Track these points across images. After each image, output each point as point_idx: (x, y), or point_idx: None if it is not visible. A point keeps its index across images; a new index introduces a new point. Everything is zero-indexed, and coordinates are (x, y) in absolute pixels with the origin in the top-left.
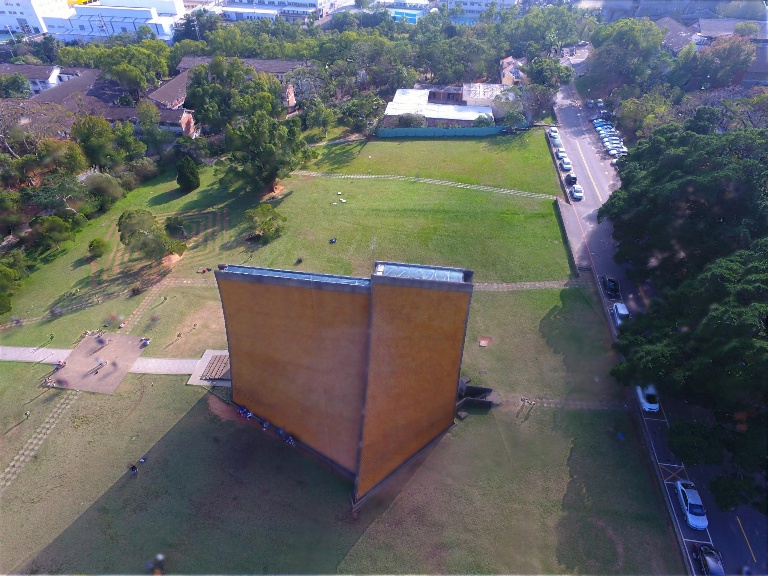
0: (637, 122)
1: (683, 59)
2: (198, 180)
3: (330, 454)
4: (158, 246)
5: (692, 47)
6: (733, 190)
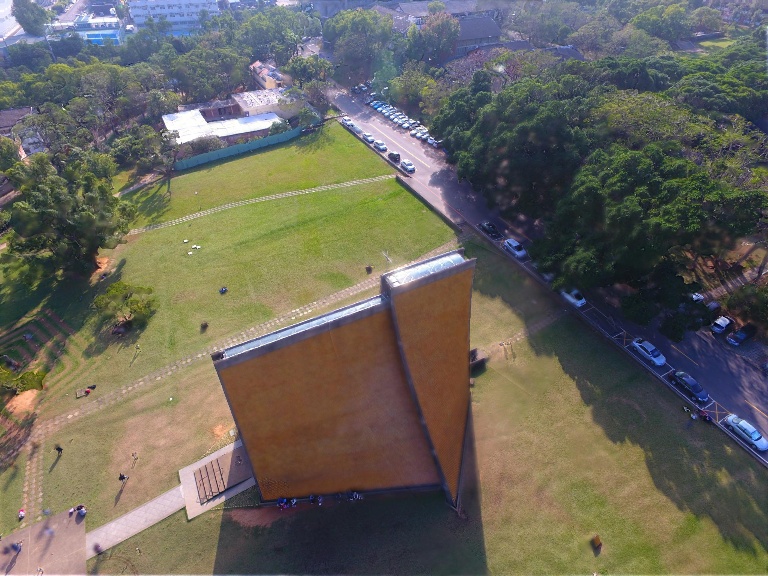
0: (409, 96)
1: (412, 38)
2: None
3: (402, 482)
4: None
5: (415, 27)
6: (549, 126)
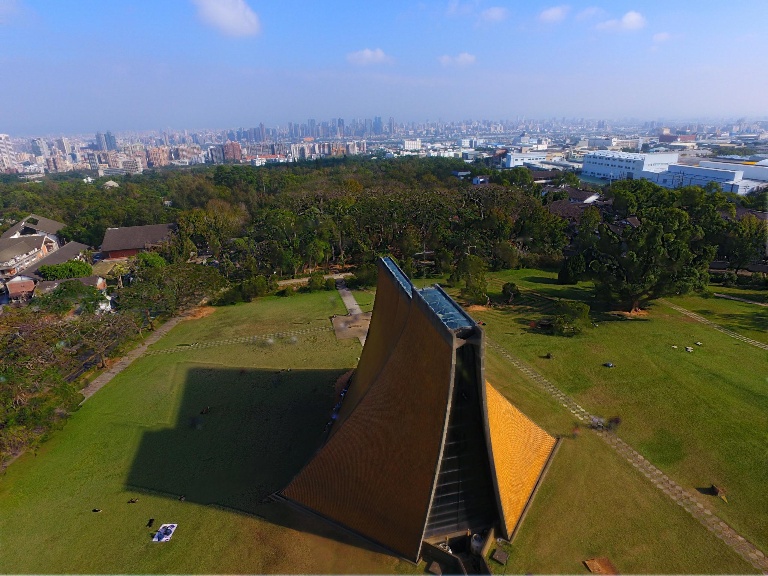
0: None
1: None
2: None
3: None
4: (473, 291)
5: None
6: None
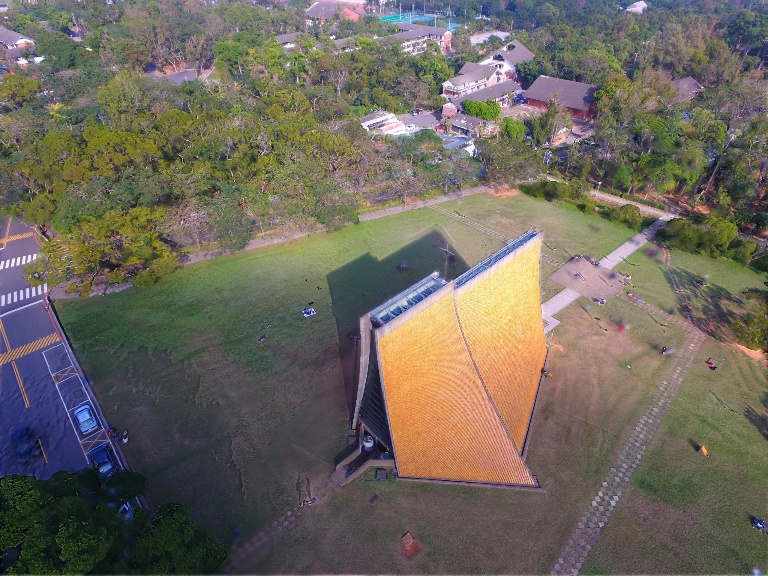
0: None
1: None
2: None
3: None
4: None
5: None
6: None
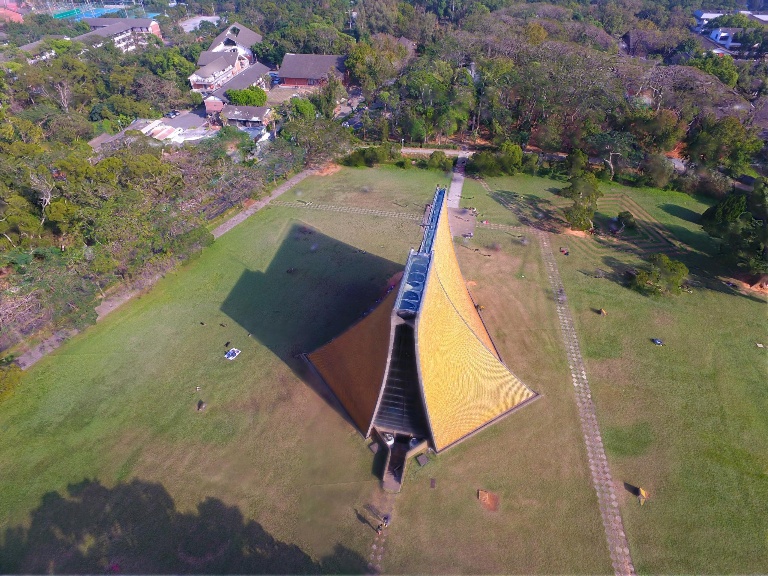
0: None
1: None
2: None
3: None
4: None
5: None
6: None
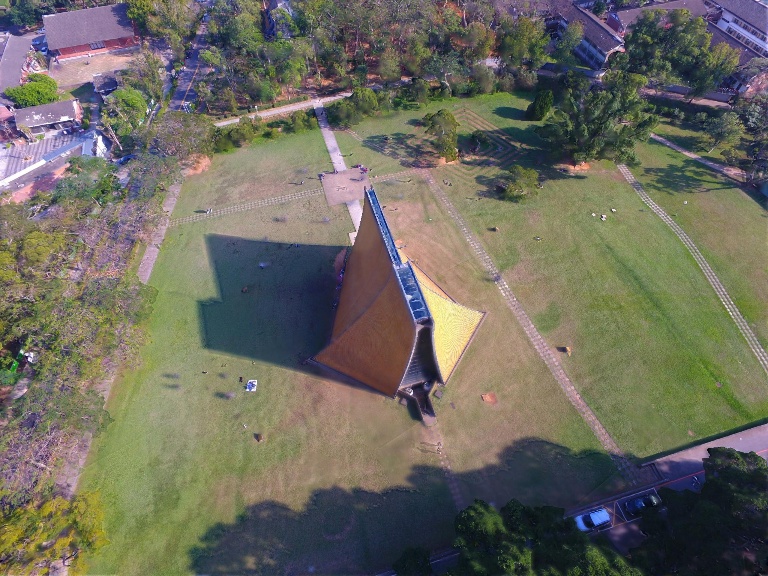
0: None
1: None
2: (543, 115)
3: (334, 331)
4: (445, 145)
5: None
6: None
